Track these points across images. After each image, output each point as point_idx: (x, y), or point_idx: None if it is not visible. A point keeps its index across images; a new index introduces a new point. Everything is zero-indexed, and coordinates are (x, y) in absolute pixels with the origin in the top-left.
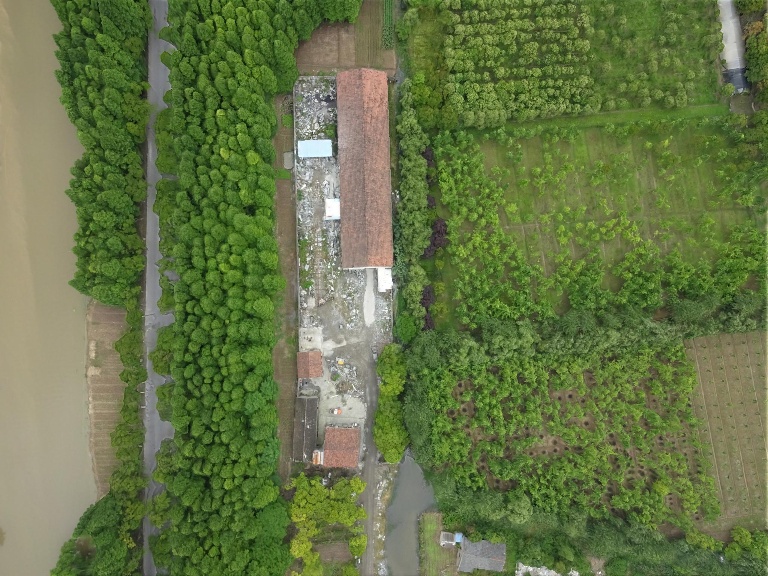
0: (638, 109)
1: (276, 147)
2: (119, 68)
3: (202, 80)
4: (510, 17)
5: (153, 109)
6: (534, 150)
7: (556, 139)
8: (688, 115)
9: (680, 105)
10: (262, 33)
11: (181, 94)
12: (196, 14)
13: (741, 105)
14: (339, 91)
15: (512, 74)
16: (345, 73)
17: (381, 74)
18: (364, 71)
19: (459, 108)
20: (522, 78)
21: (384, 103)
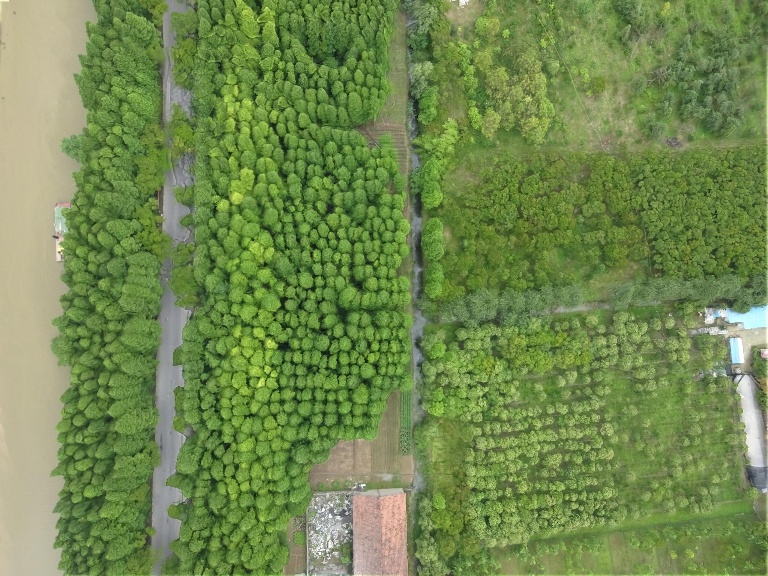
0: (662, 510)
1: (287, 569)
2: (123, 531)
3: (213, 558)
4: (533, 428)
5: (157, 558)
6: (556, 558)
7: (580, 557)
8: (712, 514)
9: (705, 512)
10: (277, 490)
11: (190, 575)
12: (208, 480)
13: (764, 500)
14: (355, 517)
15: (535, 488)
16: (362, 498)
17: (400, 497)
18: (382, 500)
19: (481, 535)
20: (545, 492)
21: (402, 528)
